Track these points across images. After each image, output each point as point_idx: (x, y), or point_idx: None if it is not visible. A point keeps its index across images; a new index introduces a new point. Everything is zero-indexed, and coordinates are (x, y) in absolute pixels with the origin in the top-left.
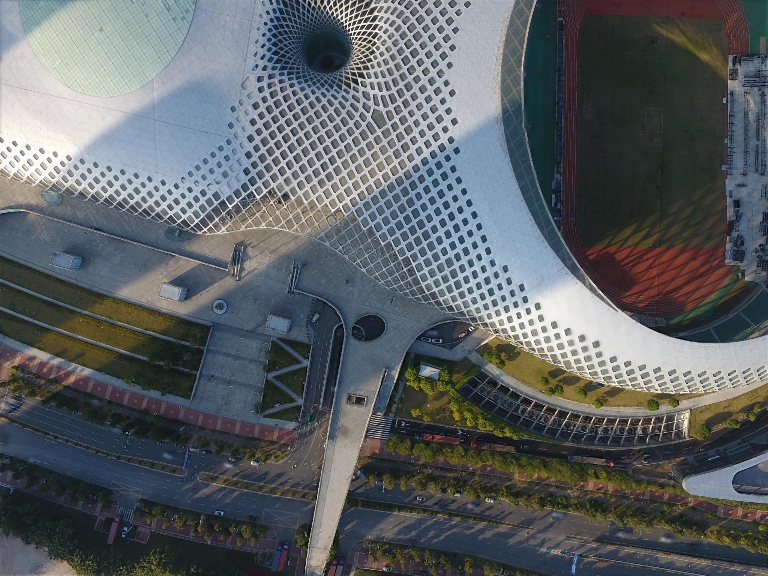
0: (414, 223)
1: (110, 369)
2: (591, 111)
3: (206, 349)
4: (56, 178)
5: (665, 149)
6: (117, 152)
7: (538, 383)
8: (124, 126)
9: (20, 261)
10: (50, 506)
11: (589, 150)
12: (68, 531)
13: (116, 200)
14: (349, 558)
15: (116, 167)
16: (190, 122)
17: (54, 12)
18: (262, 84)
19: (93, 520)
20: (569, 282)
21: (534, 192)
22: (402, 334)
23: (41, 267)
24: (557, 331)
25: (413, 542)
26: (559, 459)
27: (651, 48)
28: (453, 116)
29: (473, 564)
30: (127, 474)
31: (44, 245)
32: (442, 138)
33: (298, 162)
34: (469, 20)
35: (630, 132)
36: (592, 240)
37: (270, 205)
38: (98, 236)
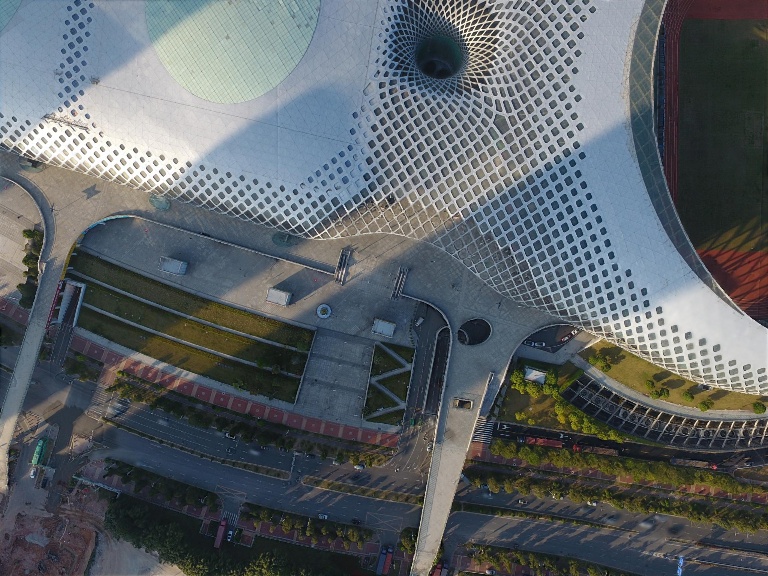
0: (535, 228)
1: (214, 373)
2: (692, 114)
3: (310, 353)
4: (174, 184)
5: (766, 152)
6: (238, 158)
7: (642, 386)
8: (246, 132)
9: (126, 266)
10: (156, 510)
11: (690, 153)
12: (178, 535)
13: (232, 206)
14: (452, 561)
15: (236, 173)
16: (312, 128)
17: (181, 20)
18: (384, 90)
19: (198, 524)
20: (695, 286)
21: (663, 197)
22: (508, 338)
23: (147, 272)
24: (677, 335)
25: (515, 545)
26: (663, 462)
27: (752, 51)
28: (579, 121)
29: (578, 567)
30: (231, 478)
31: (150, 250)
32: (567, 143)
33: (418, 167)
34: (595, 26)
35: (731, 135)
36: (694, 243)
37: (388, 210)
38: (203, 241)
